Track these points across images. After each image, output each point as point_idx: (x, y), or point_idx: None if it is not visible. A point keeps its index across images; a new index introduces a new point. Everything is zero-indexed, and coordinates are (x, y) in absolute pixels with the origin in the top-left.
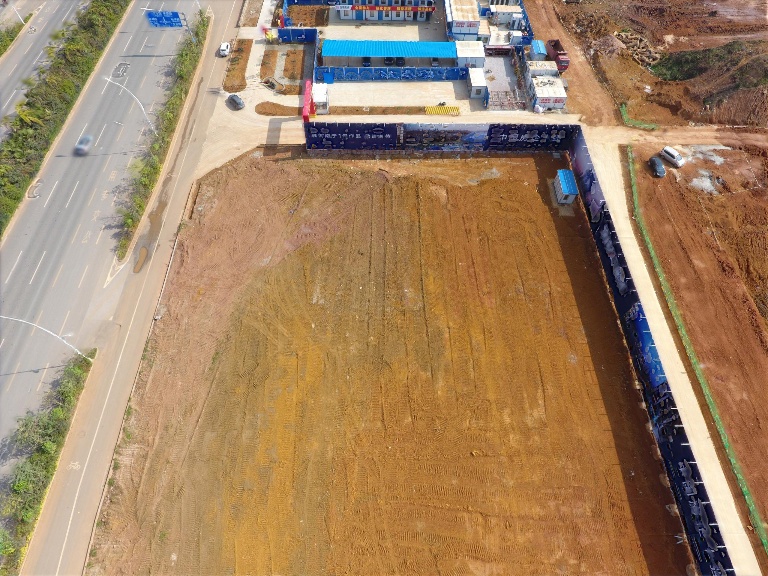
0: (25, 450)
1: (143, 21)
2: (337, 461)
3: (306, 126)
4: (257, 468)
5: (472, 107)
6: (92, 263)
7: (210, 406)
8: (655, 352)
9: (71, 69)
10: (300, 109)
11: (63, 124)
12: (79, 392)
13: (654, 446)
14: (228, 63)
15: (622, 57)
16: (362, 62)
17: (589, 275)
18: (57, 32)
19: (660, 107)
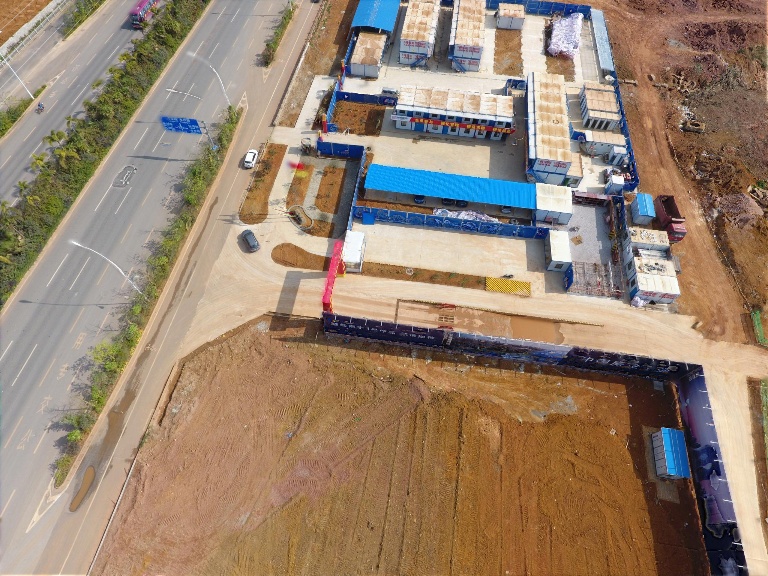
0: None
1: (165, 107)
2: None
3: (325, 316)
4: None
5: (548, 285)
6: (21, 486)
7: None
8: None
9: (63, 178)
10: (327, 261)
11: (39, 253)
12: None
13: None
14: (252, 178)
15: (758, 230)
16: (414, 198)
17: None
18: (63, 118)
19: None
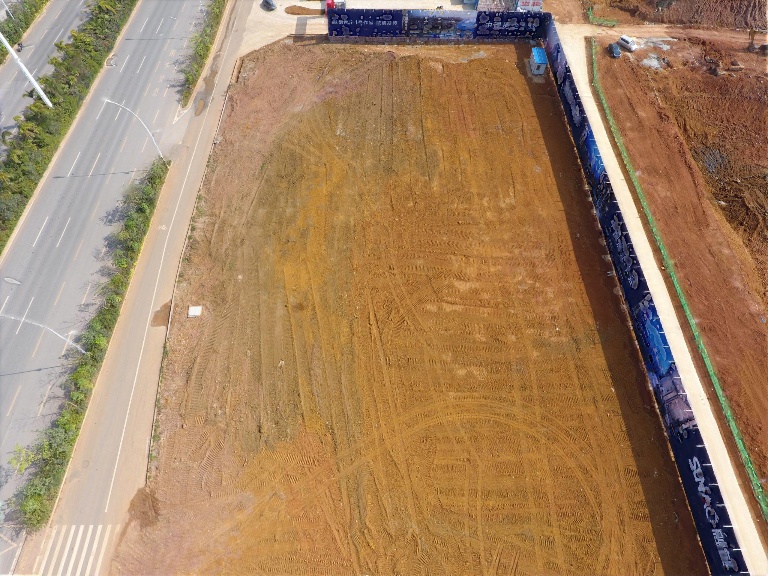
0: (126, 215)
1: None
2: (357, 226)
3: (329, 12)
4: (298, 229)
5: None
6: (162, 108)
7: (261, 194)
8: (597, 152)
9: None
10: (322, 10)
11: (129, 17)
12: (161, 185)
13: (596, 222)
14: None
15: None
16: None
17: (554, 119)
18: None
19: (621, 11)
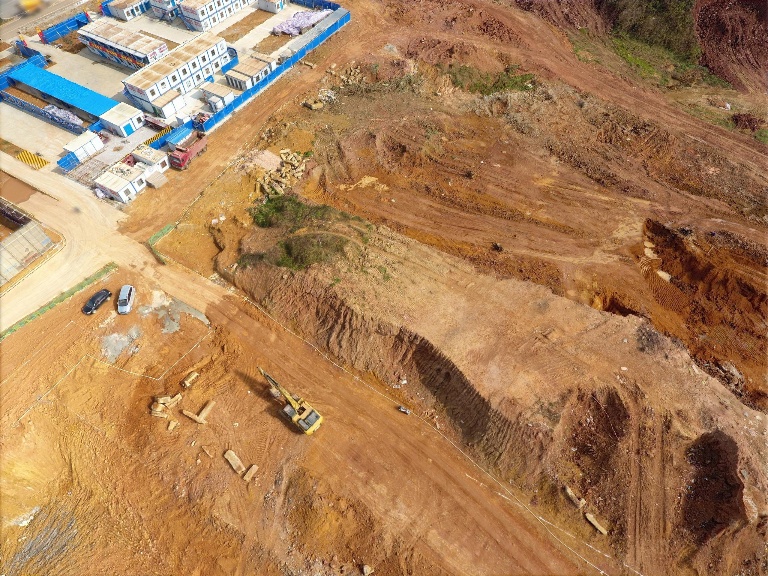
0: None
1: None
2: None
3: None
4: None
5: (58, 167)
6: None
7: None
8: None
9: None
10: None
11: None
12: None
13: None
14: None
15: (249, 177)
16: (40, 93)
17: None
18: None
19: (212, 244)
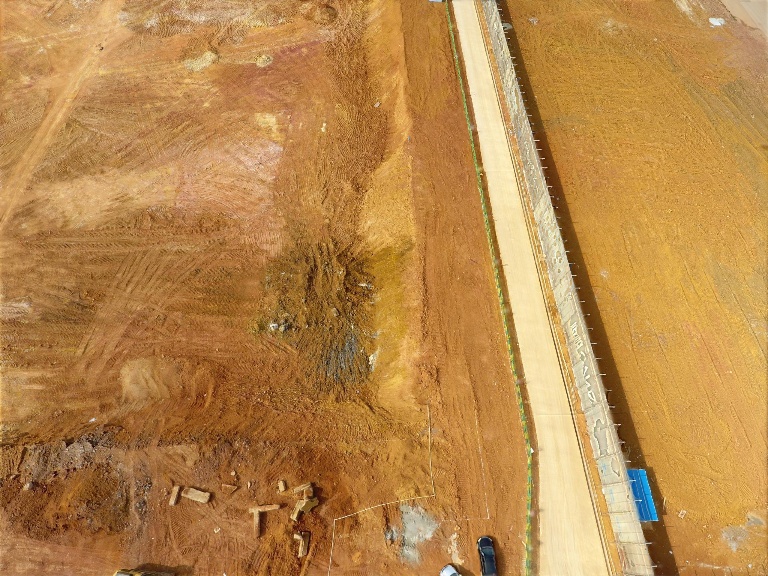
0: None
1: None
2: (760, 209)
3: None
4: None
5: None
6: None
7: None
8: None
9: None
10: None
11: None
12: None
13: None
14: None
15: None
16: None
17: None
18: None
19: None
